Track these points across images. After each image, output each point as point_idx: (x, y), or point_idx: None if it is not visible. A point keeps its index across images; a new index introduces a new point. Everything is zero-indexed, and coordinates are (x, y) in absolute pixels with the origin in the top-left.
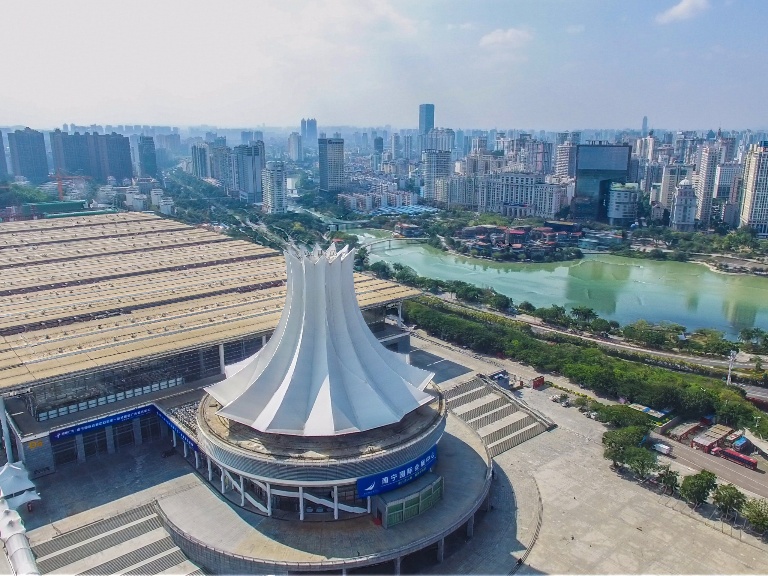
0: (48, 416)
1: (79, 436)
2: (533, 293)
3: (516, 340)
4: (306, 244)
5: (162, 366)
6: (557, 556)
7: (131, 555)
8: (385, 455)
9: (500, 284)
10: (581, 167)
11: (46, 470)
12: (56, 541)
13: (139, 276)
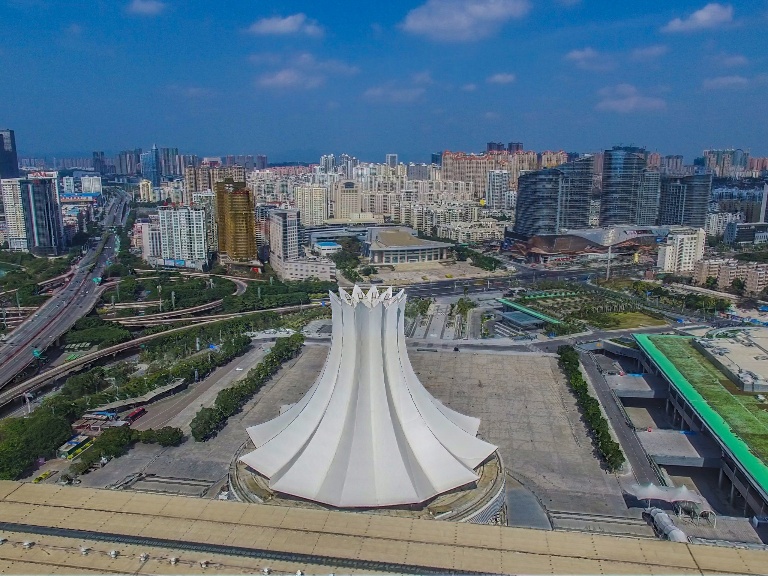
0: None
1: None
2: None
3: None
4: None
5: None
6: None
7: None
8: None
9: None
10: None
11: None
12: None
13: None
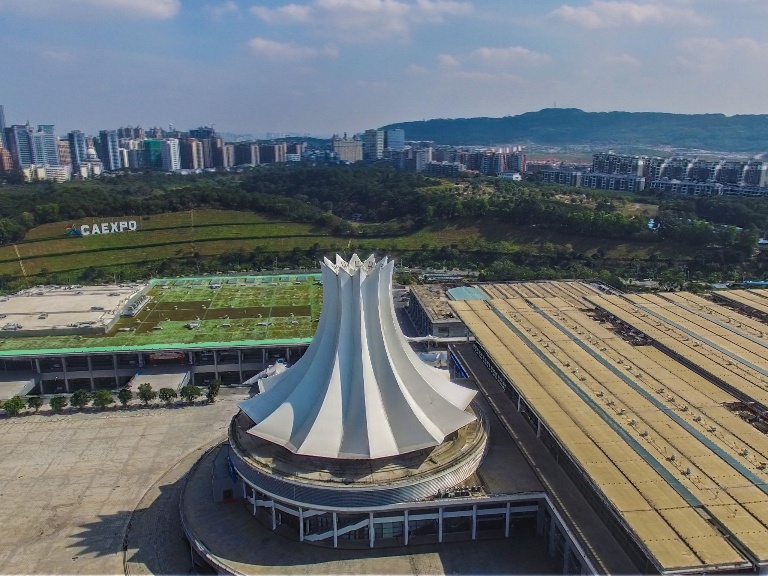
0: None
1: None
2: None
3: None
4: None
5: None
6: (97, 575)
7: None
8: None
9: None
10: None
11: None
12: None
13: None
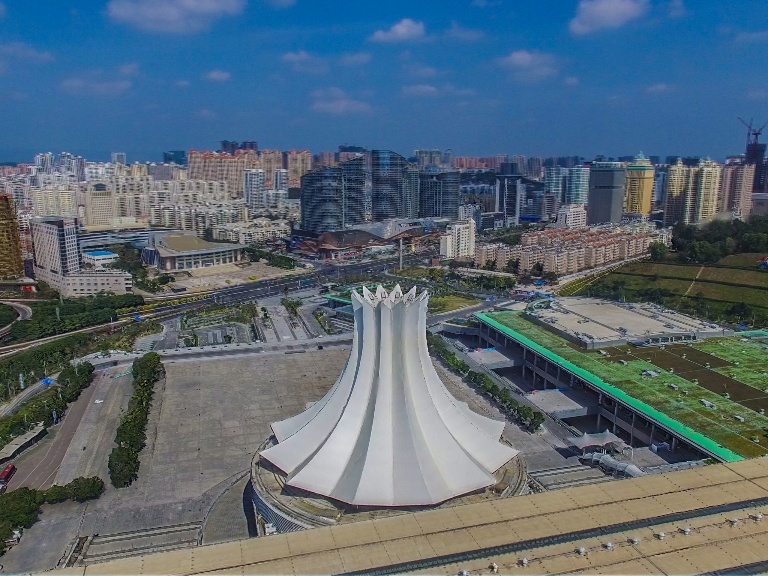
0: None
1: None
2: None
3: None
4: None
5: None
6: None
7: None
8: None
9: None
10: None
11: None
12: None
13: None
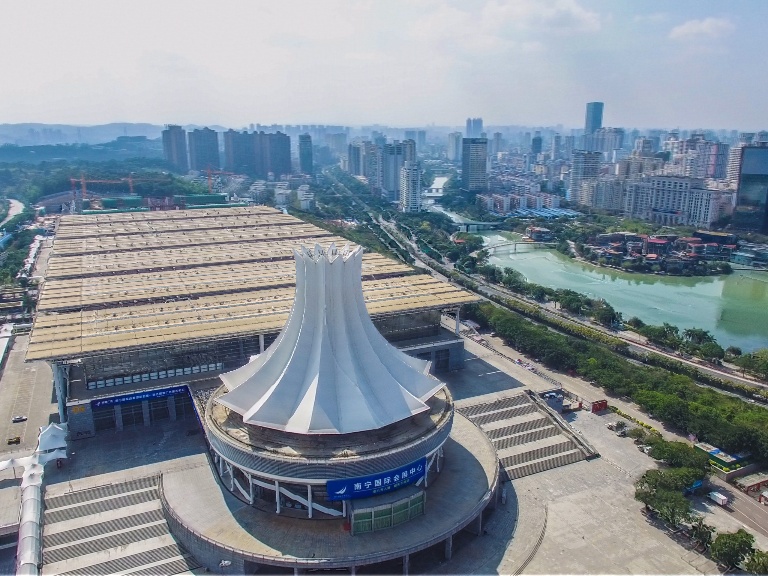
0: (96, 385)
1: (118, 406)
2: (654, 309)
3: (592, 358)
4: (424, 243)
5: (203, 350)
6: None
7: (122, 520)
8: (358, 461)
9: (620, 296)
10: (745, 171)
11: (88, 433)
12: (66, 497)
13: (226, 265)
